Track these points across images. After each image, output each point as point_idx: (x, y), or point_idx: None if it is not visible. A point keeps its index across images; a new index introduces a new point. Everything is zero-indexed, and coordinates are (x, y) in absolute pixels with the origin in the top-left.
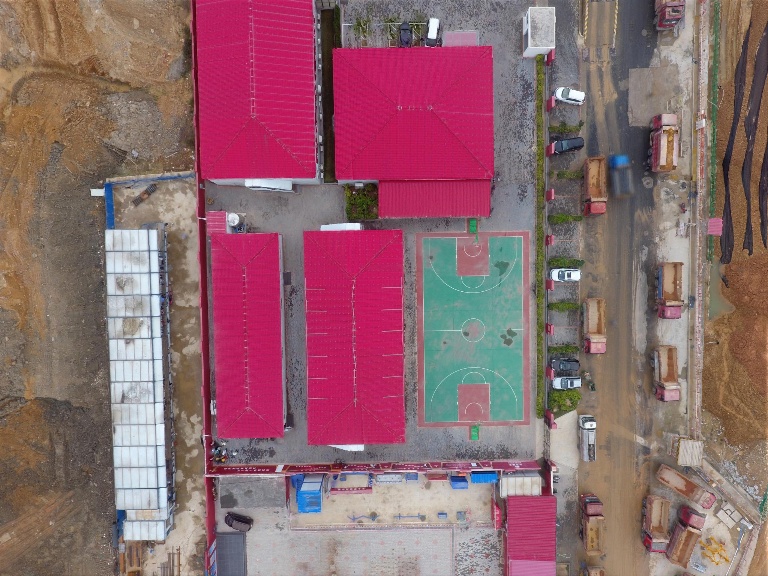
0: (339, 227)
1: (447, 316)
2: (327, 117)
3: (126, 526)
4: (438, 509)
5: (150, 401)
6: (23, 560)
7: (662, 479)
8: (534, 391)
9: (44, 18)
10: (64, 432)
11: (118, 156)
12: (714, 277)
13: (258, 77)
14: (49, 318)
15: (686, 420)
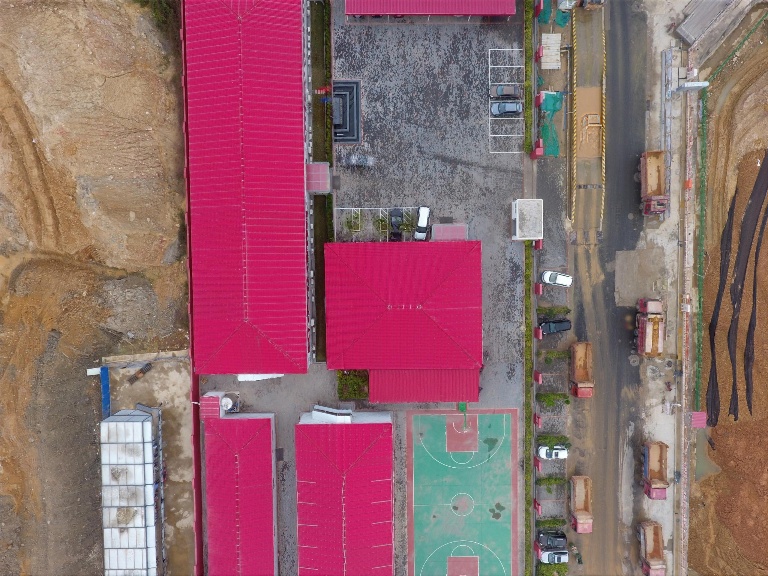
0: (330, 418)
1: (437, 491)
2: (319, 298)
3: None
4: None
5: None
6: None
7: None
8: (522, 563)
9: (42, 213)
10: None
11: (114, 336)
12: (700, 439)
13: (251, 282)
14: (45, 501)
15: None
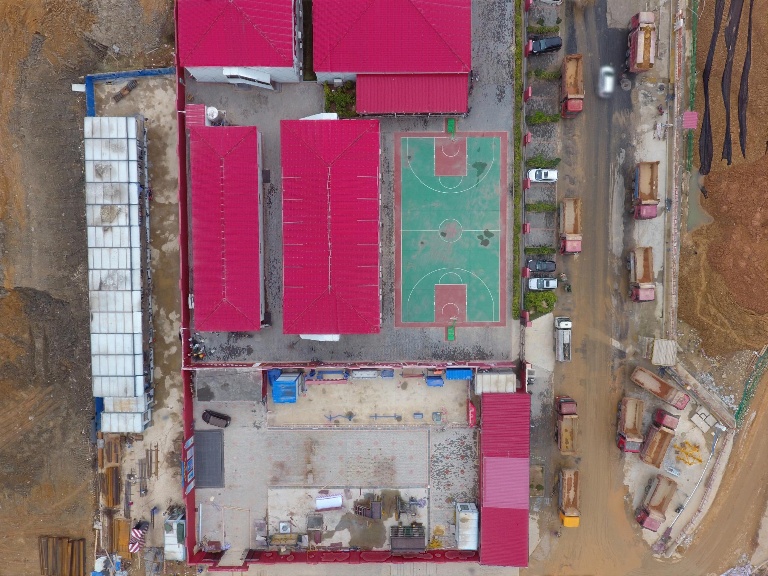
0: (316, 118)
1: (425, 216)
2: (307, 15)
3: (104, 418)
4: (414, 410)
5: (127, 289)
6: (3, 455)
7: (637, 381)
8: (510, 292)
9: None
10: (44, 326)
11: (99, 52)
12: (693, 188)
13: None
14: (29, 208)
15: (662, 324)
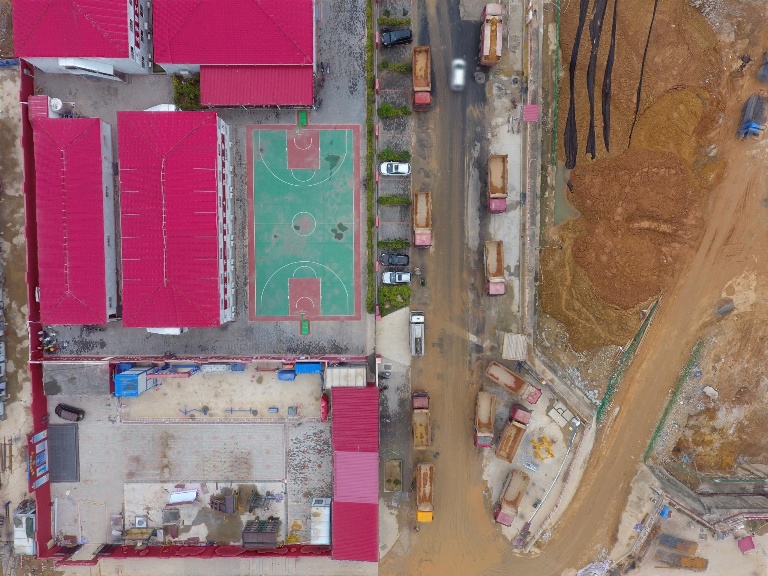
0: (155, 109)
1: (278, 209)
2: None
3: None
4: (270, 404)
5: None
6: None
7: (491, 375)
8: (365, 286)
9: None
10: None
11: None
12: (559, 182)
13: None
14: None
15: (518, 318)
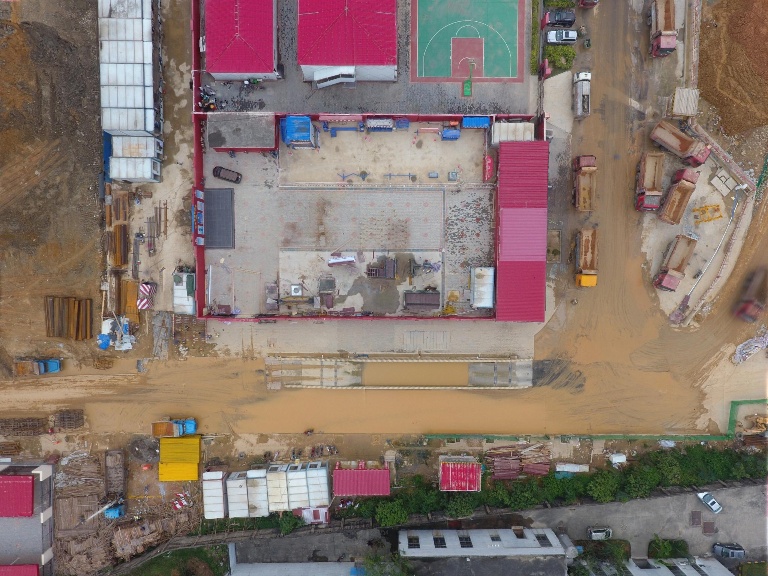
0: None
1: None
2: None
3: (112, 162)
4: (429, 169)
5: (138, 16)
6: (8, 211)
7: None
8: (529, 47)
9: None
10: (51, 73)
11: None
12: None
13: None
14: None
15: (682, 83)
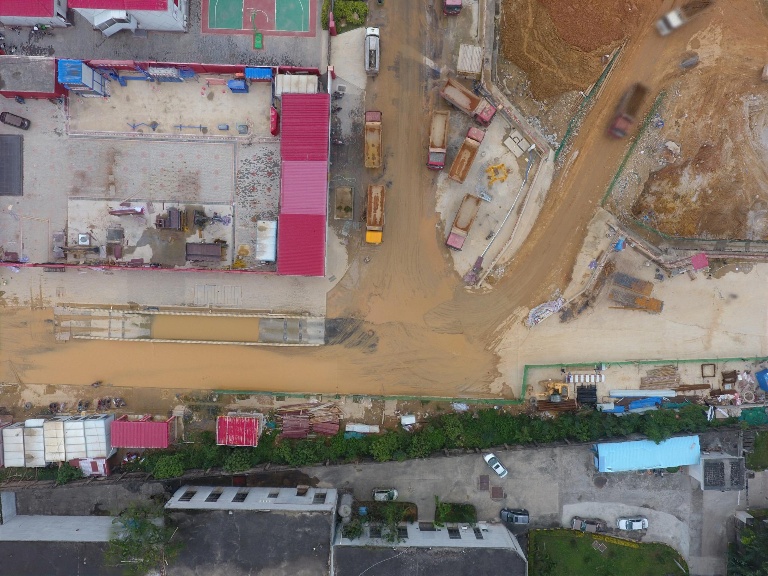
0: None
1: None
2: None
3: None
4: (220, 122)
5: None
6: None
7: None
8: (321, 2)
9: None
10: None
11: None
12: None
13: None
14: None
15: (476, 43)
